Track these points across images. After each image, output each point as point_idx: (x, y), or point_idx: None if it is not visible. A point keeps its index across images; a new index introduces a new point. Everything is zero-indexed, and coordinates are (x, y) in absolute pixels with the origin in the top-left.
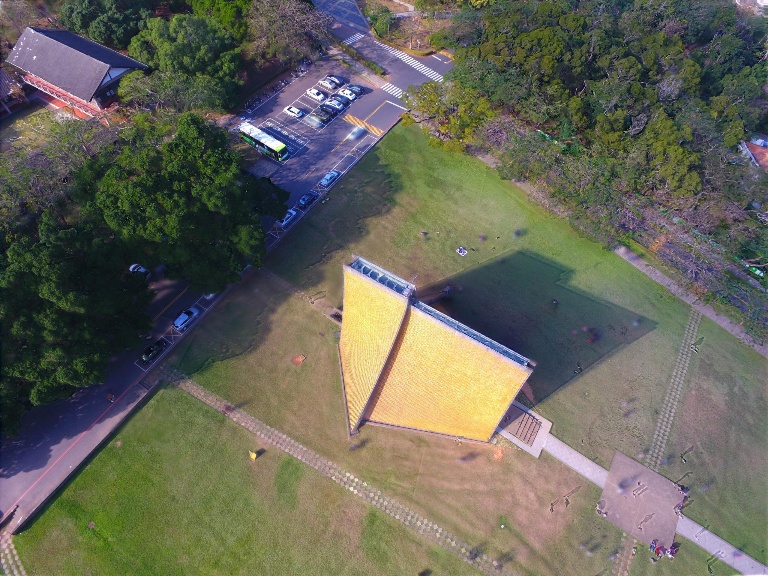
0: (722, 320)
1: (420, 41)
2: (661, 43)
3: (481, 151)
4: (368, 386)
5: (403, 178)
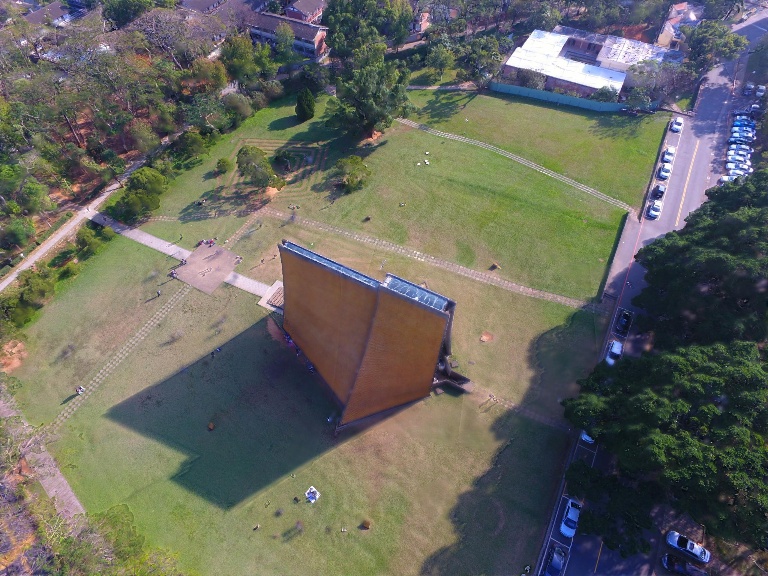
0: None
1: None
2: None
3: None
4: None
5: None
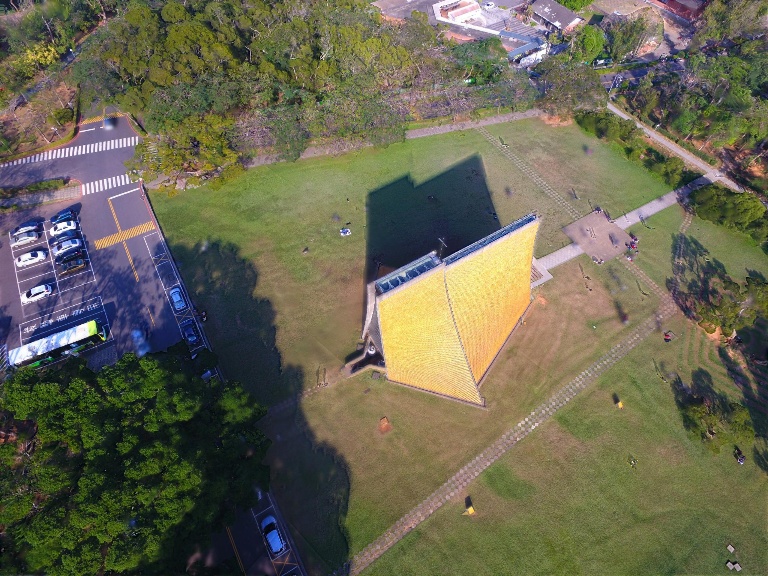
0: (491, 120)
1: (56, 127)
2: None
3: (245, 161)
4: (460, 362)
5: (228, 235)
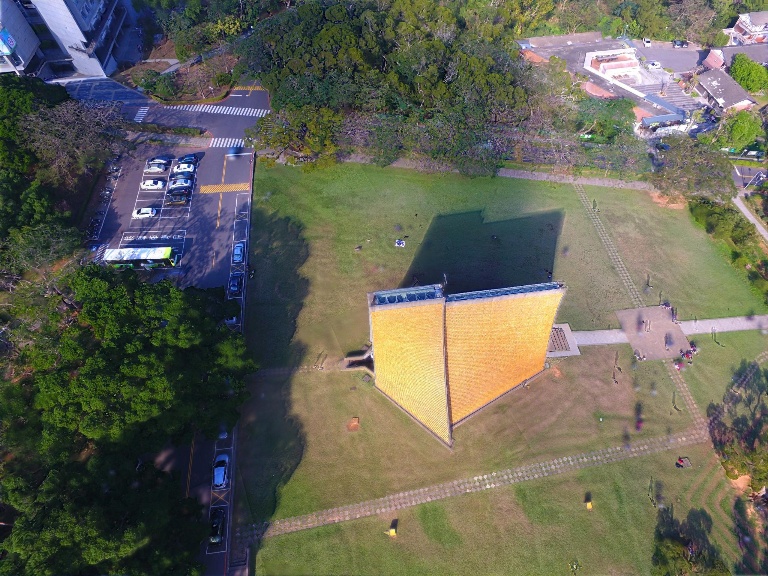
0: (594, 181)
1: (212, 87)
2: (409, 3)
3: (344, 155)
4: (440, 396)
5: (301, 213)
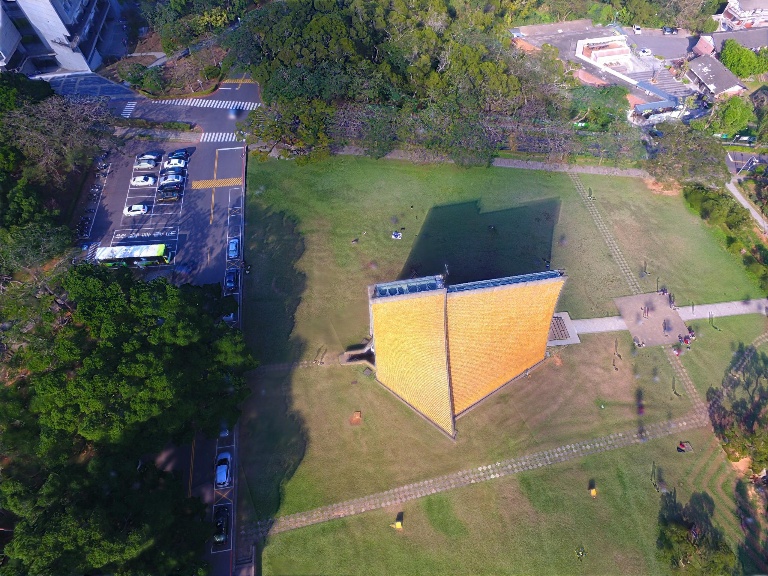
0: (589, 169)
1: (201, 80)
2: None
3: (337, 147)
4: (442, 388)
5: (296, 207)
